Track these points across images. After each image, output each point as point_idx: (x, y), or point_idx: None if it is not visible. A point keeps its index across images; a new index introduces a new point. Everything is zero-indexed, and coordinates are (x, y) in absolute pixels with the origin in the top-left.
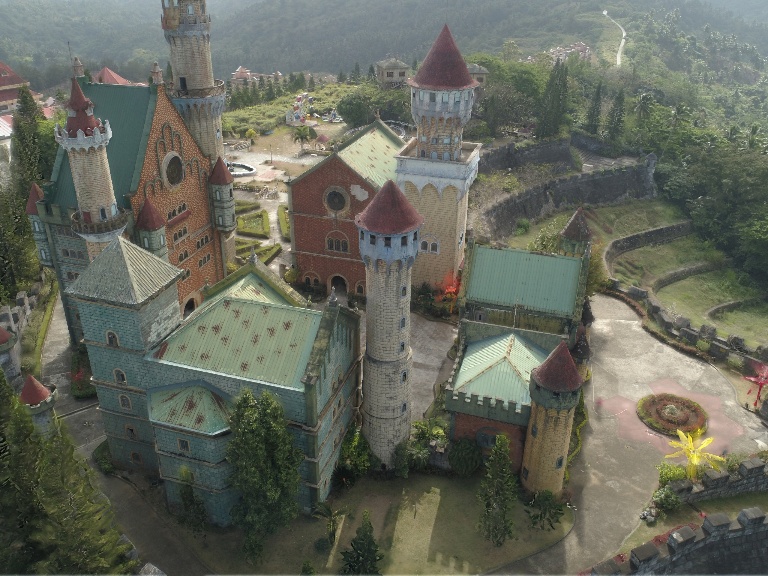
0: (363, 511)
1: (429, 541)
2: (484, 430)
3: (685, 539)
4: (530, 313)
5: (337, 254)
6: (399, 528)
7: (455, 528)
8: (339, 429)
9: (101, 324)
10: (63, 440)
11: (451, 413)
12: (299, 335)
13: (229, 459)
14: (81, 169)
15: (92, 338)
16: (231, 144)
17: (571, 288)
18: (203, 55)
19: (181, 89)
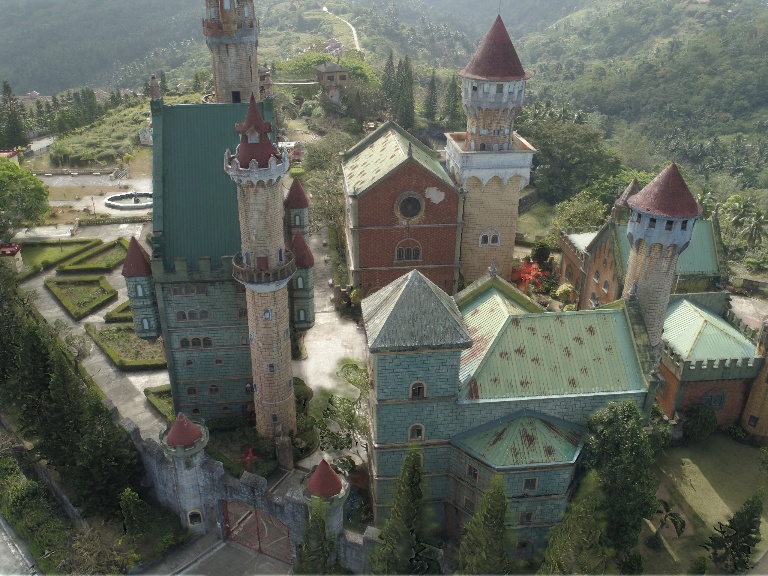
0: (760, 488)
1: (727, 506)
2: (710, 392)
3: None
4: (683, 278)
5: (407, 263)
6: (693, 504)
7: (733, 488)
8: None
9: (406, 376)
10: None
11: (681, 384)
12: (608, 337)
13: (607, 481)
14: (263, 206)
15: (389, 396)
16: (104, 173)
17: (709, 248)
18: (255, 63)
19: None
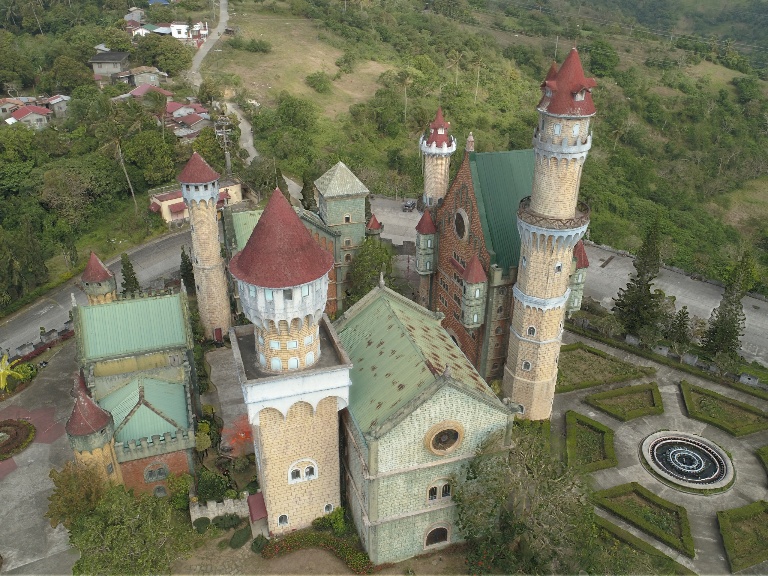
0: None
1: None
2: None
3: (24, 344)
4: None
5: None
6: None
7: None
8: None
9: None
10: None
11: None
12: None
13: None
14: None
15: None
16: None
17: None
18: None
19: None
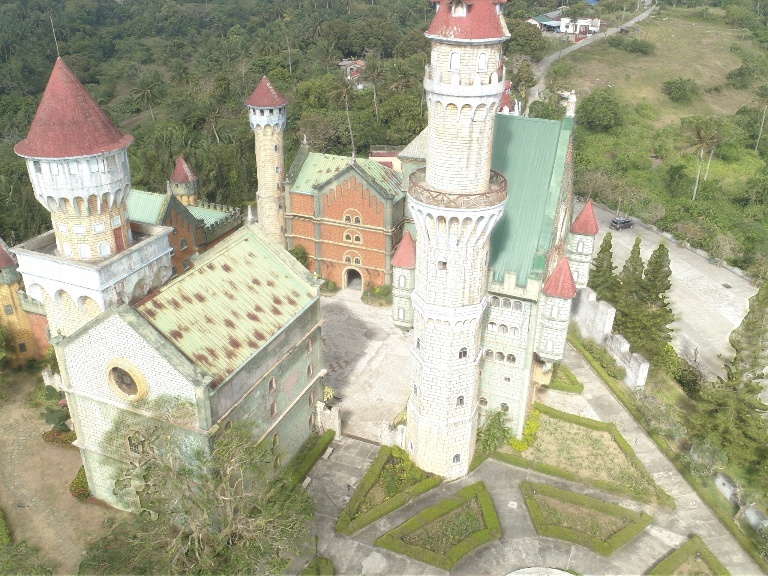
0: None
1: None
2: None
3: None
4: None
5: None
6: None
7: None
8: None
9: None
10: None
11: None
12: None
13: None
14: None
15: None
16: None
17: None
18: None
19: None
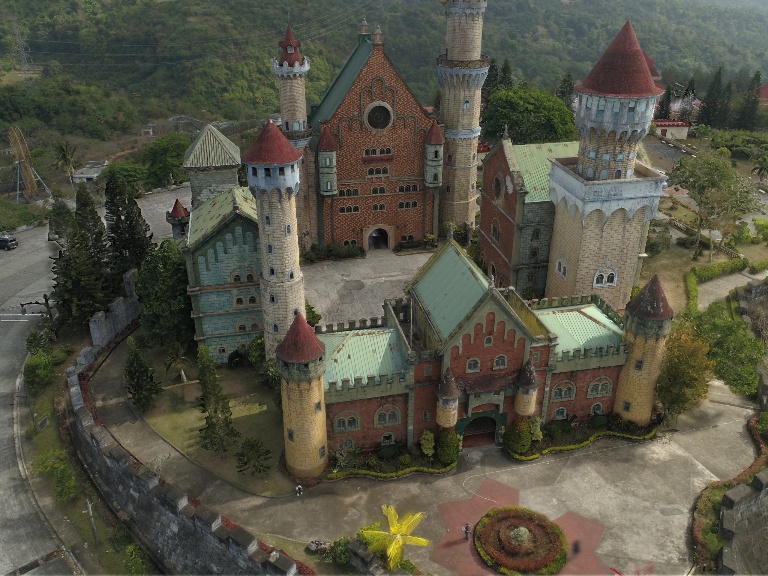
0: None
1: None
2: None
3: (275, 563)
4: None
5: None
6: None
7: None
8: (252, 321)
9: None
10: (62, 203)
11: None
12: None
13: None
14: None
15: None
16: None
17: (463, 317)
18: (464, 31)
19: (439, 58)
